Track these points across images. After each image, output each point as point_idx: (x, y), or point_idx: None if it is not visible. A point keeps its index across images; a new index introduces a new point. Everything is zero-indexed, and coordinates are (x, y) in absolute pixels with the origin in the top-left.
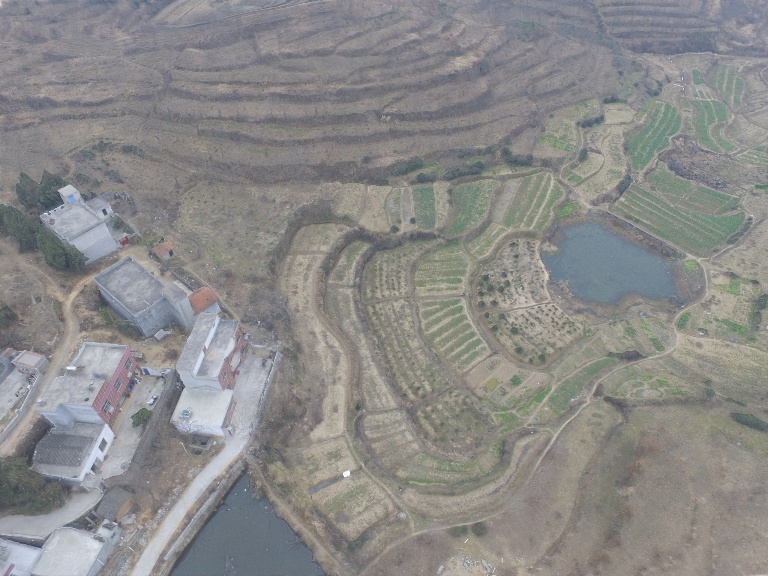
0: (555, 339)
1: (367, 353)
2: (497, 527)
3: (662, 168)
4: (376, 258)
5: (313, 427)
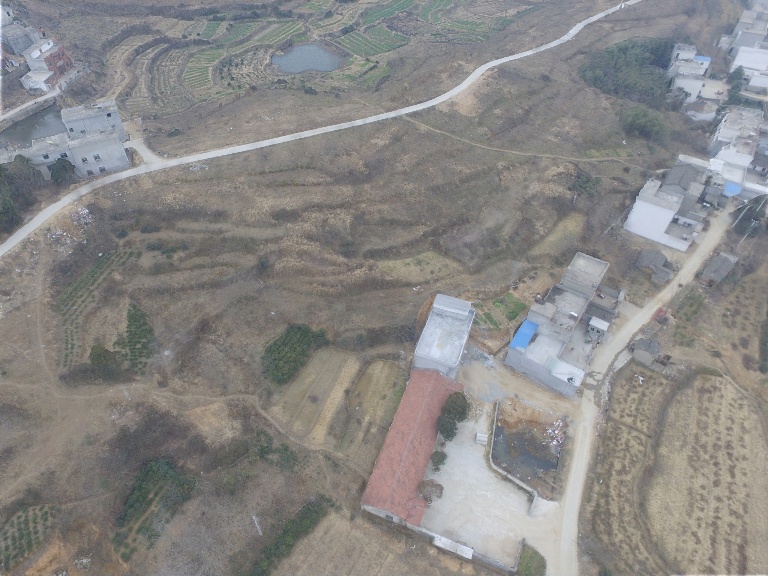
0: (253, 82)
1: (143, 80)
2: (165, 118)
3: (381, 26)
4: (171, 51)
5: (99, 98)
